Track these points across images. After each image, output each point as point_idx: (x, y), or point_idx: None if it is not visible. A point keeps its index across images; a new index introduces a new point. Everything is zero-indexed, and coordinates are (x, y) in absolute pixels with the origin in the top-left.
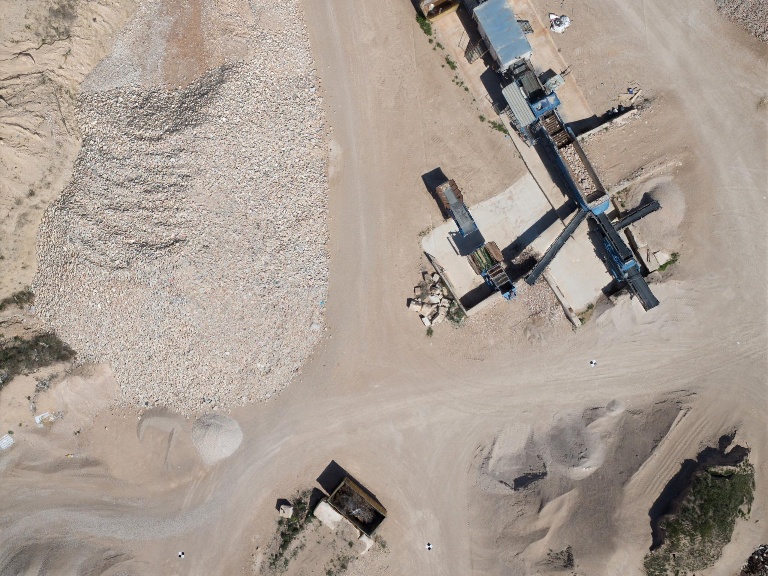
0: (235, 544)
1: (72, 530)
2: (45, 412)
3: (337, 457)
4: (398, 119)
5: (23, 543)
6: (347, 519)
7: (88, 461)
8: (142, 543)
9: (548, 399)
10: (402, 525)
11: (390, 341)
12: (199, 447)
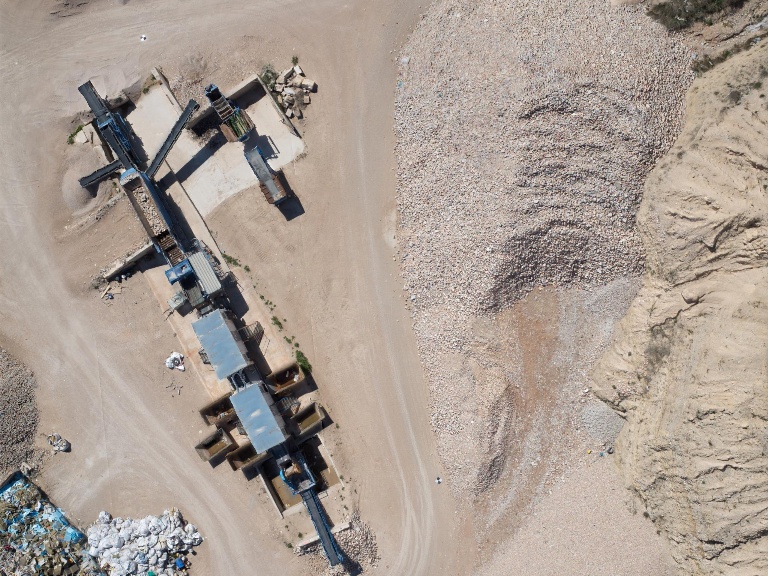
0: None
1: None
2: None
3: None
4: (328, 268)
5: None
6: None
7: None
8: None
9: (184, 3)
10: None
11: (333, 50)
12: None
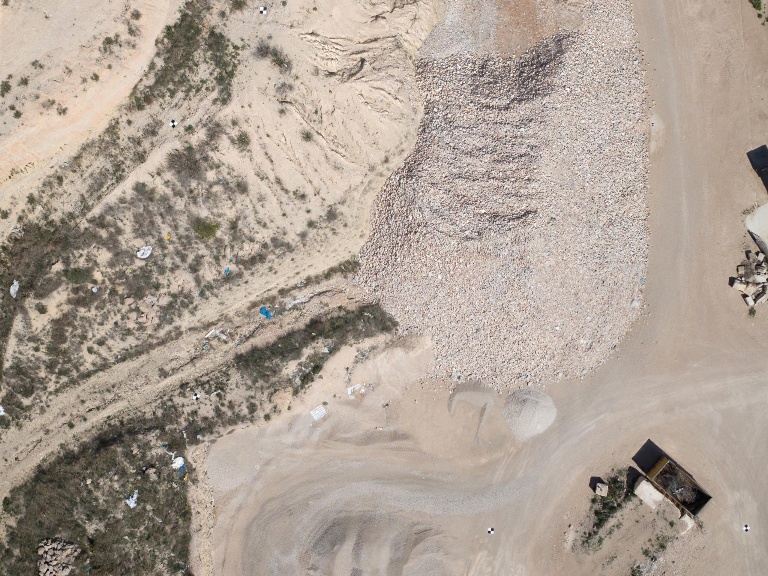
0: (546, 521)
1: (382, 503)
2: (357, 384)
3: (653, 436)
4: (723, 95)
5: (335, 515)
6: (668, 498)
7: (397, 434)
8: (451, 518)
9: None
10: (719, 506)
11: (711, 320)
12: (512, 423)
